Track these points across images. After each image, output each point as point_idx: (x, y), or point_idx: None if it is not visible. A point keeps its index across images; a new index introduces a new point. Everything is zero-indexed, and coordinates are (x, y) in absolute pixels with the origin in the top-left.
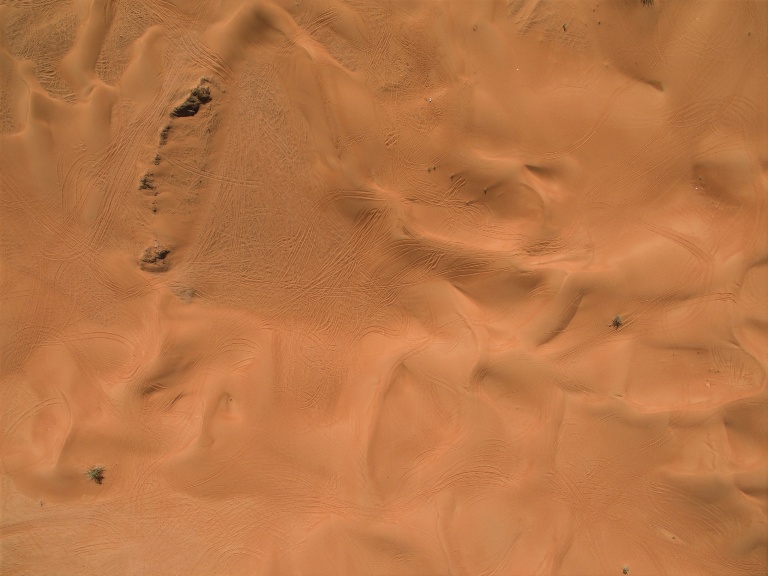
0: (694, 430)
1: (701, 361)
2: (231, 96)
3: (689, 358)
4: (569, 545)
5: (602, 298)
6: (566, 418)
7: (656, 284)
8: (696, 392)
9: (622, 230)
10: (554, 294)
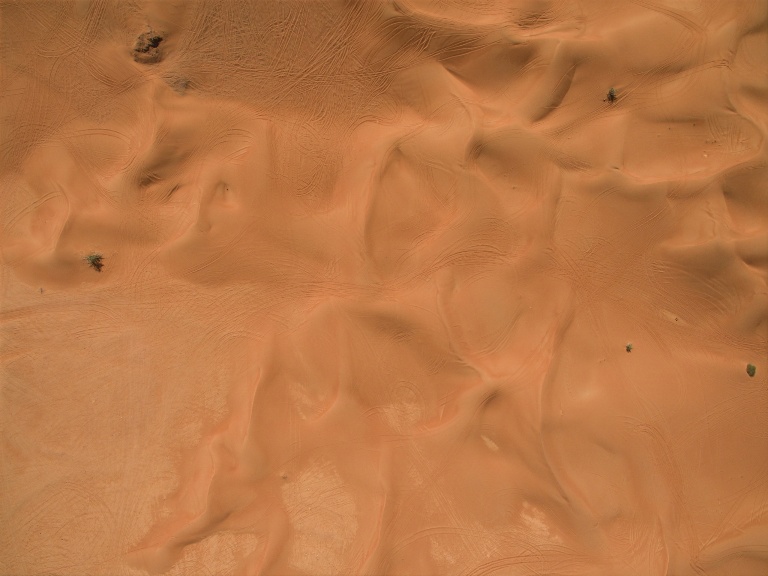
0: (693, 200)
1: (698, 133)
2: None
3: (685, 131)
4: (571, 320)
5: (595, 70)
6: (563, 195)
7: (649, 55)
8: (694, 163)
9: (613, 5)
10: (547, 65)
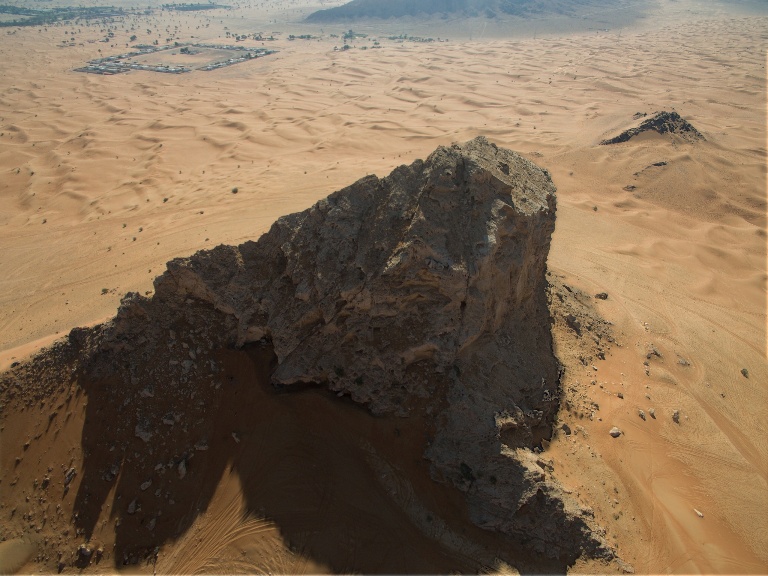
0: None
1: None
2: (673, 166)
3: None
4: None
5: None
6: None
7: None
8: None
9: None
10: None
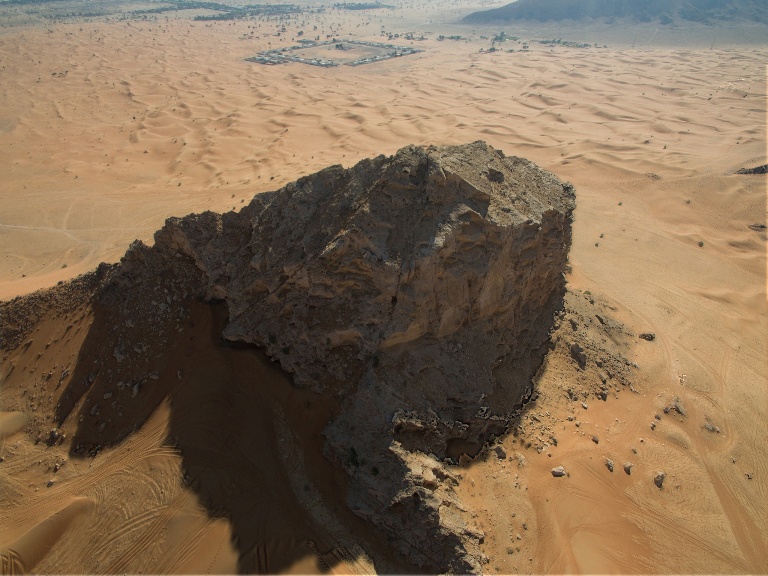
0: None
1: None
2: None
3: None
4: None
5: None
6: None
7: None
8: None
9: None
10: None
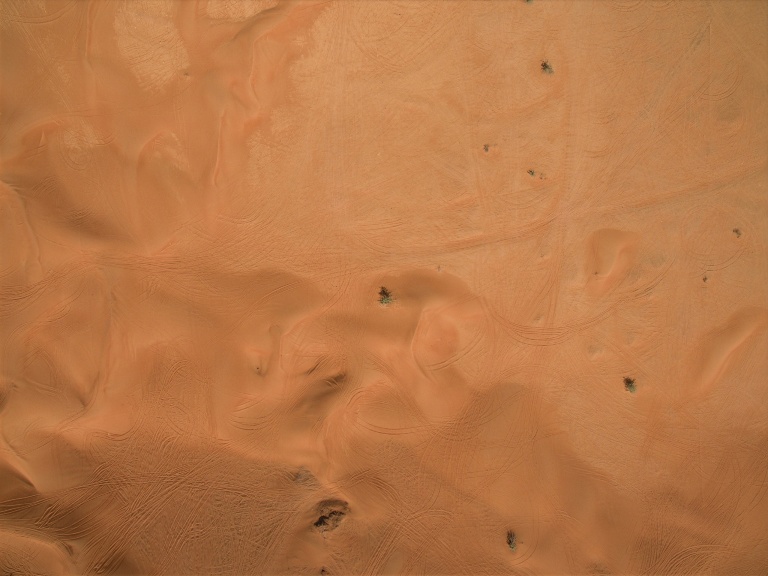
0: None
1: None
2: None
3: None
4: None
5: None
6: None
7: None
8: None
9: None
10: None
